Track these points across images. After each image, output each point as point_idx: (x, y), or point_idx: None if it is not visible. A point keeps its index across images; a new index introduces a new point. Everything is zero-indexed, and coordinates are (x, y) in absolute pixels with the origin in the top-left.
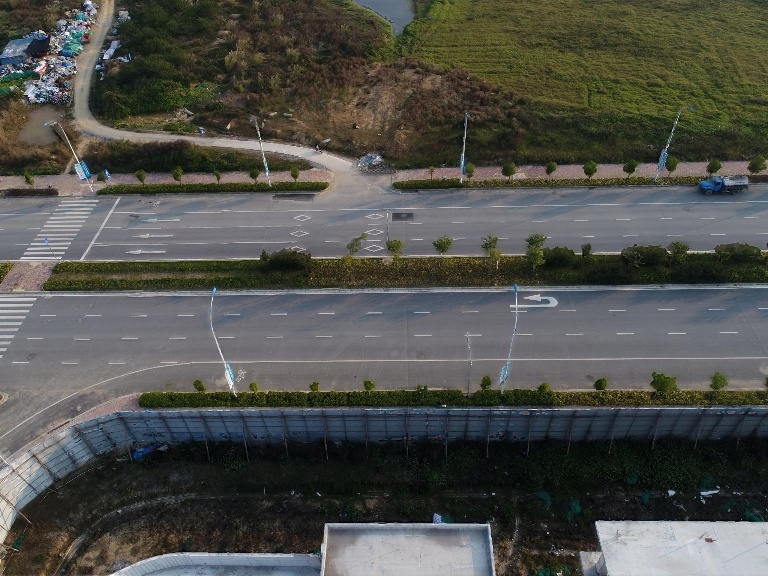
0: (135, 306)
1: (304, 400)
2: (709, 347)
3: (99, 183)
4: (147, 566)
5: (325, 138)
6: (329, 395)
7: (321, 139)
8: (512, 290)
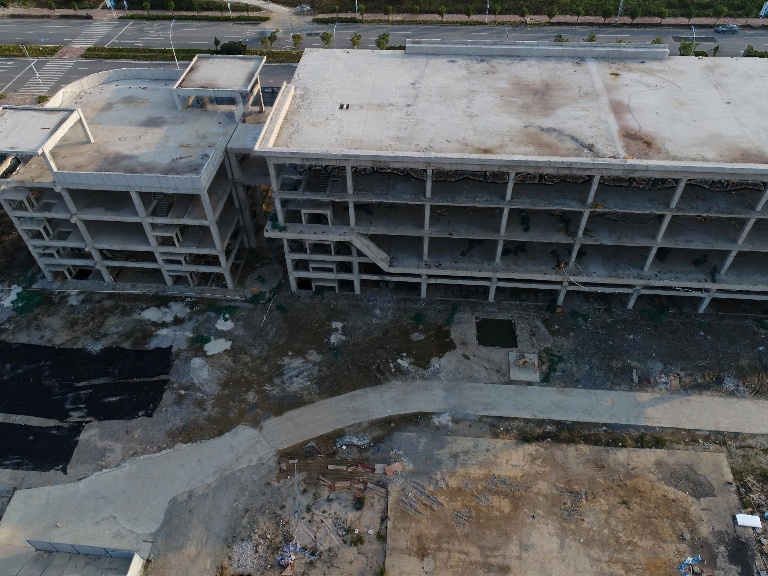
0: (135, 66)
1: None
2: None
3: (120, 14)
4: (121, 74)
5: None
6: None
7: None
8: None
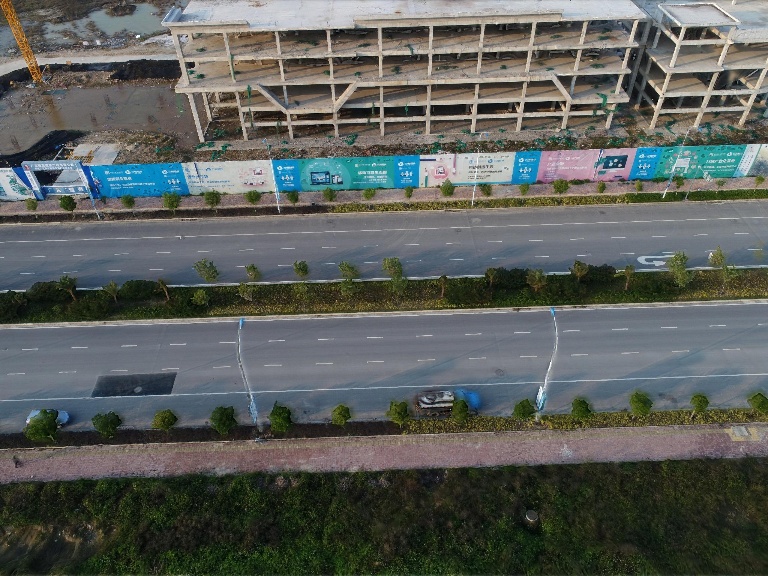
0: None
1: None
2: (513, 232)
3: None
4: None
5: None
6: None
7: None
8: None
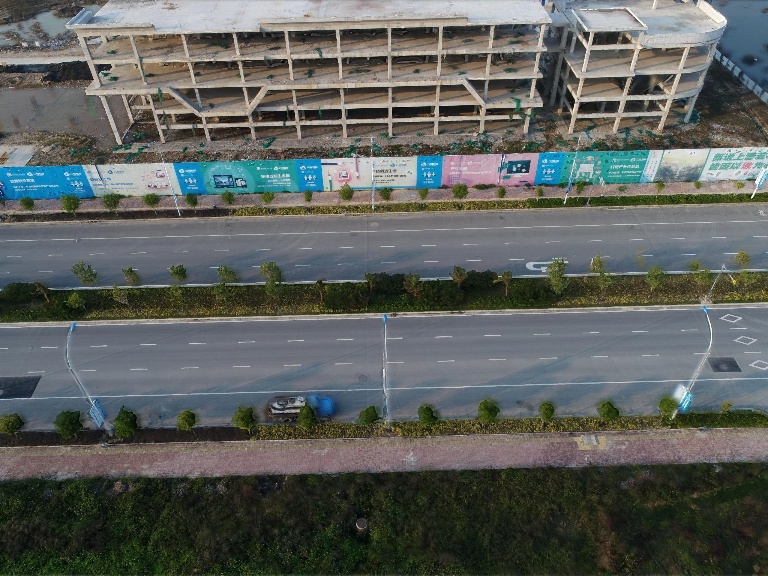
0: None
1: (701, 195)
2: (408, 237)
3: None
4: None
5: None
6: None
7: None
8: (569, 275)
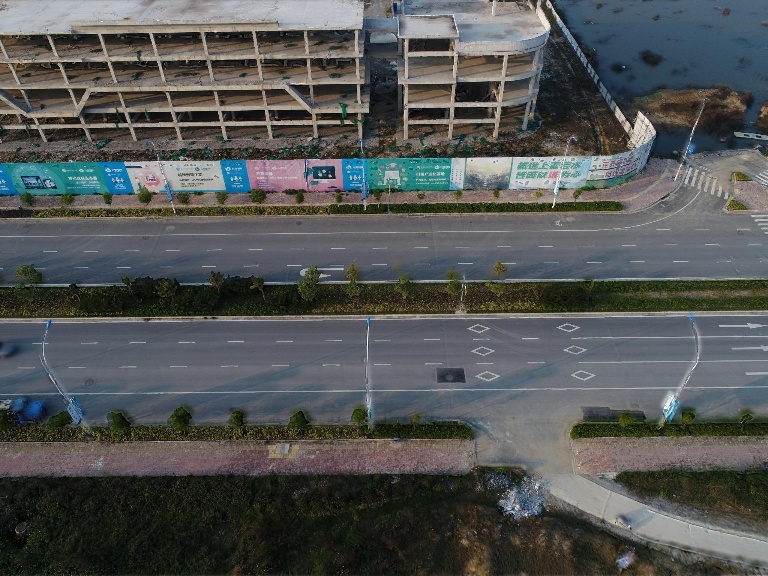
0: (693, 269)
1: (503, 204)
2: (198, 241)
3: None
4: (525, 44)
5: (630, 573)
6: (486, 207)
7: (636, 569)
8: (338, 282)
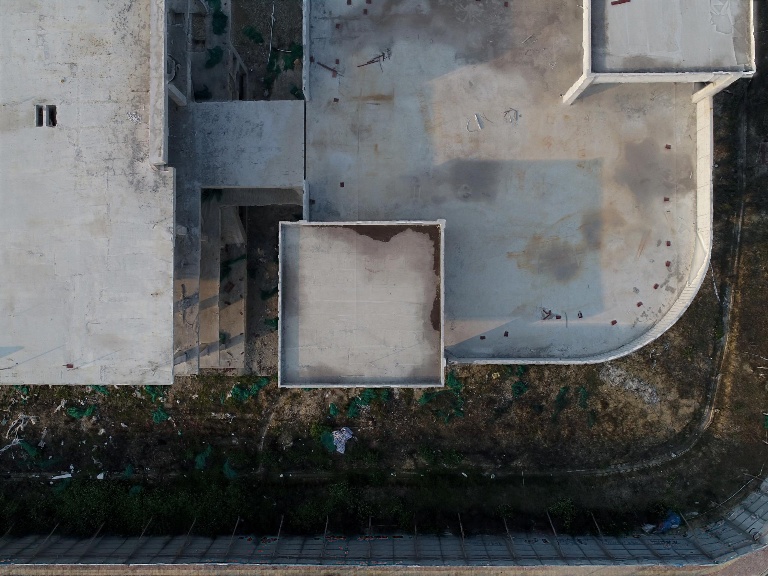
0: None
1: None
2: None
3: None
4: None
5: None
6: None
7: None
8: None
